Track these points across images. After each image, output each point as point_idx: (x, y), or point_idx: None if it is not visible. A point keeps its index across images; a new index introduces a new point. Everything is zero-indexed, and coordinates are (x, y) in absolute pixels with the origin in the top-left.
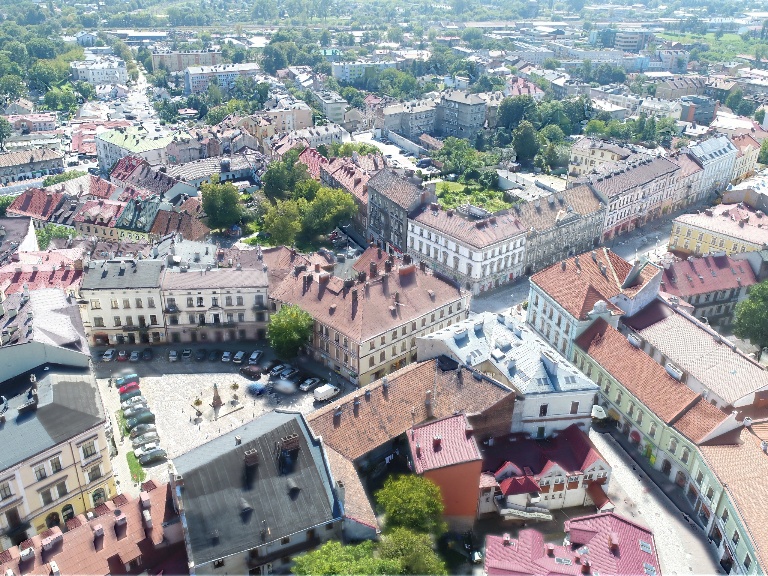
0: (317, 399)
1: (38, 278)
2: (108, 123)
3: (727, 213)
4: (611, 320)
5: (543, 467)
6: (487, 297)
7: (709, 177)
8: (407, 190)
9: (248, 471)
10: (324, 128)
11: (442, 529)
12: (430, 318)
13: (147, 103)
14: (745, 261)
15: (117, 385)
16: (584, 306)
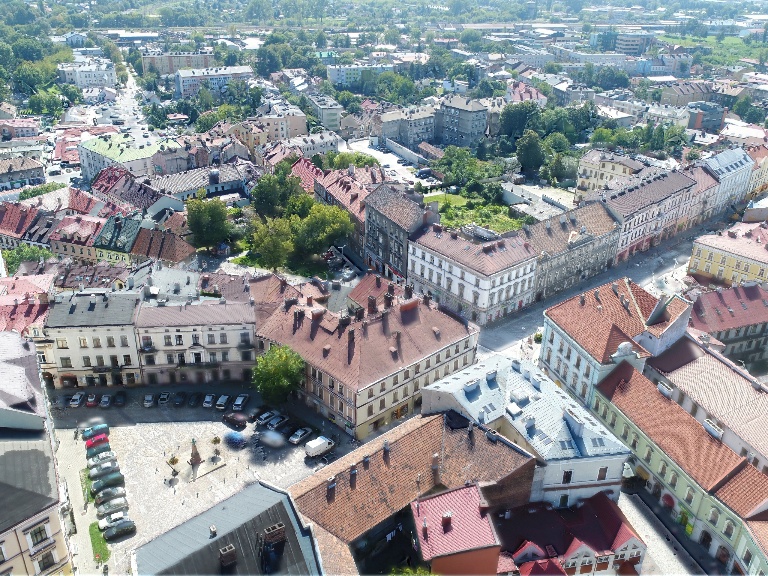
0: (309, 454)
1: None
2: (94, 129)
3: (750, 233)
4: (636, 363)
5: (568, 546)
6: (495, 328)
7: (725, 191)
8: (408, 209)
9: (224, 572)
10: (319, 136)
11: None
12: (435, 359)
13: (136, 107)
14: None
15: (84, 437)
16: (607, 348)
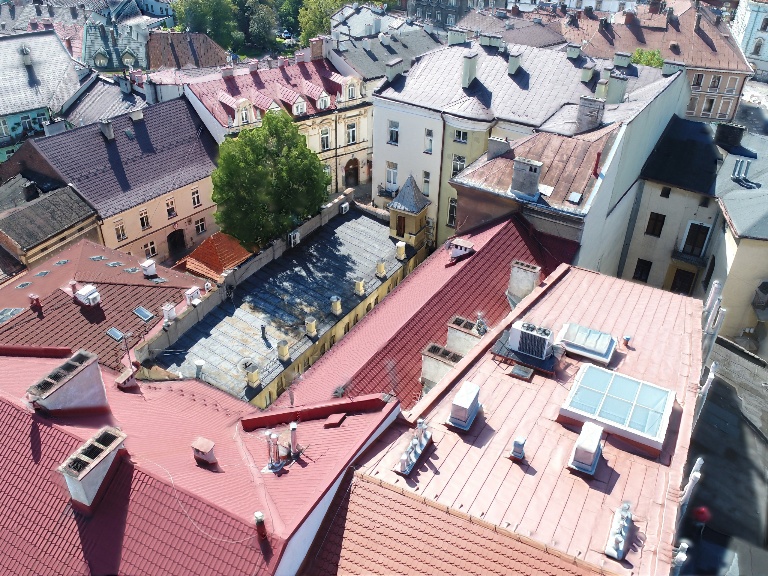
0: None
1: (267, 81)
2: None
3: None
4: None
5: None
6: None
7: None
8: None
9: None
10: None
11: None
12: None
13: None
14: None
15: None
16: None
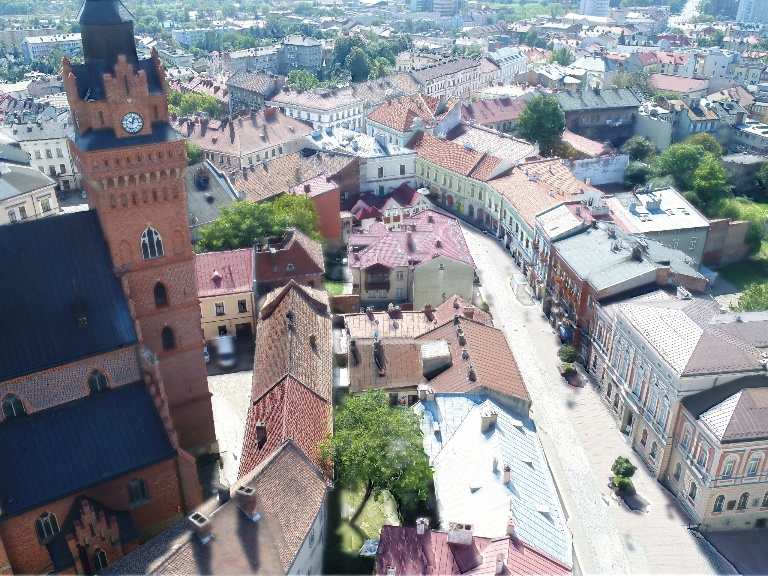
0: None
1: None
2: None
3: None
4: None
5: (384, 205)
6: None
7: (507, 77)
8: (261, 80)
9: None
10: (176, 71)
11: (317, 222)
12: None
13: None
14: (523, 101)
15: None
16: (406, 122)
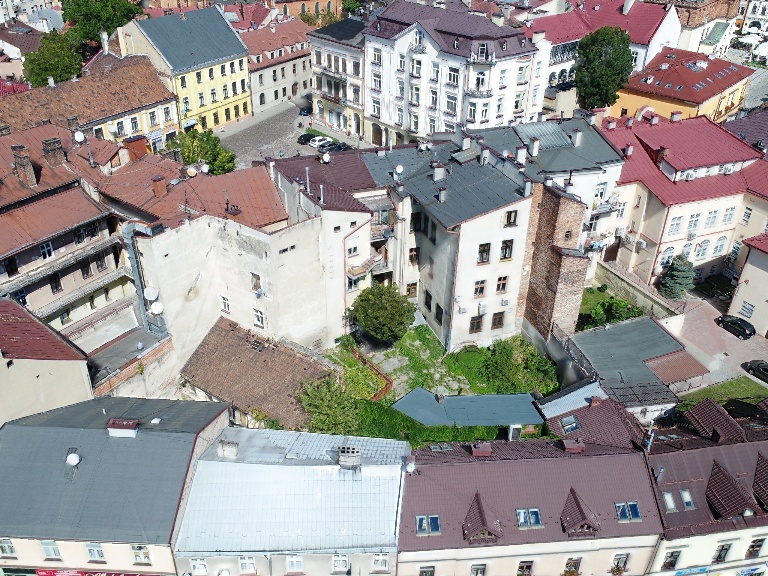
0: None
1: None
2: None
3: None
4: None
5: None
6: None
7: None
8: None
9: None
10: None
11: None
12: None
13: None
14: None
15: None
16: None
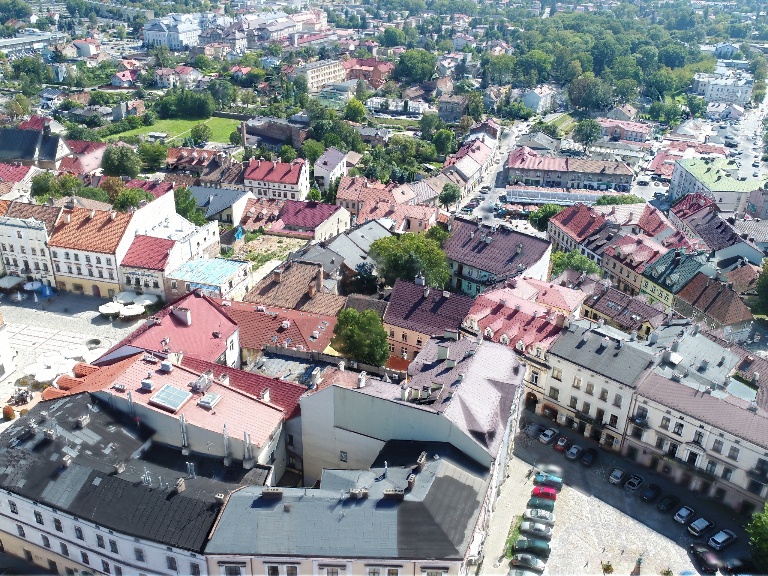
0: None
1: (516, 318)
2: (702, 146)
3: None
4: None
5: None
6: None
7: None
8: None
9: None
10: None
11: None
12: None
13: (758, 131)
14: None
15: (535, 480)
16: None
